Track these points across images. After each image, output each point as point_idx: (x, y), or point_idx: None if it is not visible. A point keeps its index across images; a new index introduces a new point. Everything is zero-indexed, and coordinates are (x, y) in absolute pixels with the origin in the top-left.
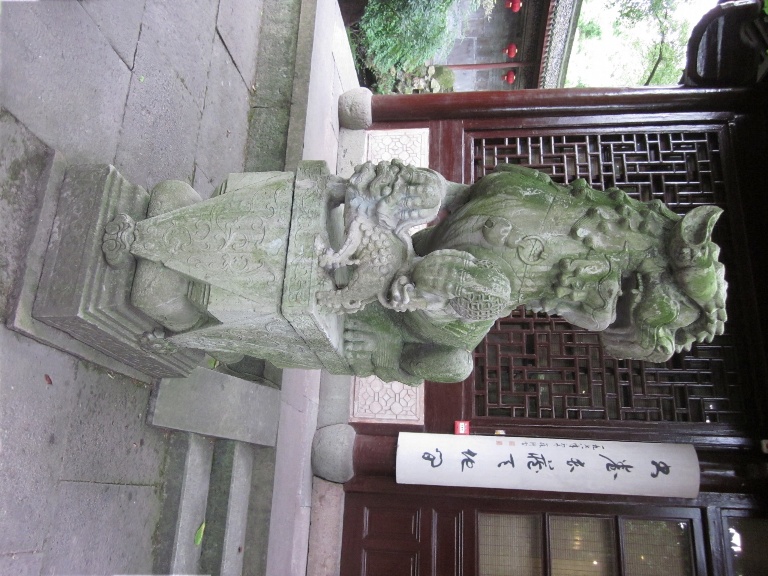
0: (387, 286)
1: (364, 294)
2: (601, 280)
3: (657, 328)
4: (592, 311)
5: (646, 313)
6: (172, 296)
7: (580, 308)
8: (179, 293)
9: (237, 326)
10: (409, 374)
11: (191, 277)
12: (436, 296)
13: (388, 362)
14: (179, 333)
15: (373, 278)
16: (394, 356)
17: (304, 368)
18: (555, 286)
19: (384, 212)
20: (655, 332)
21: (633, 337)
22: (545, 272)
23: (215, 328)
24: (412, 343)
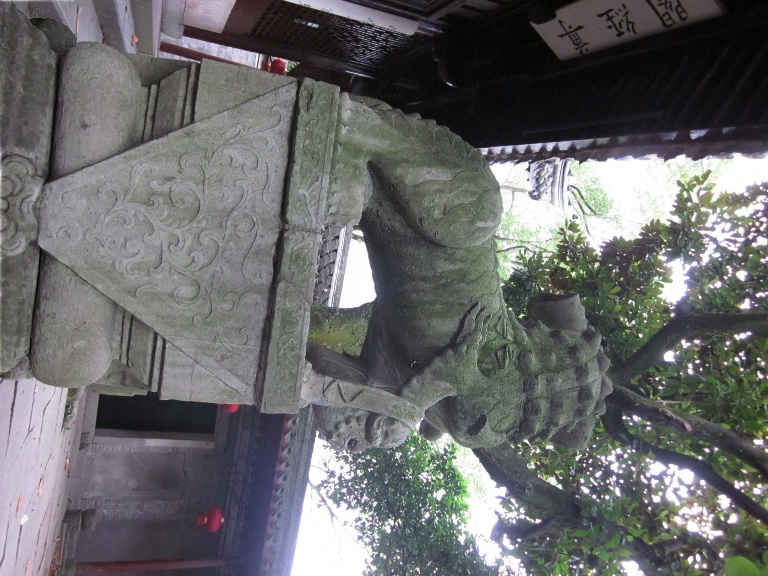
0: None
1: None
2: None
3: None
4: None
5: None
6: None
7: None
8: None
9: None
10: None
11: None
12: None
13: None
14: None
15: None
16: None
17: None
18: None
19: None
20: None
21: None
22: None
23: None
24: None
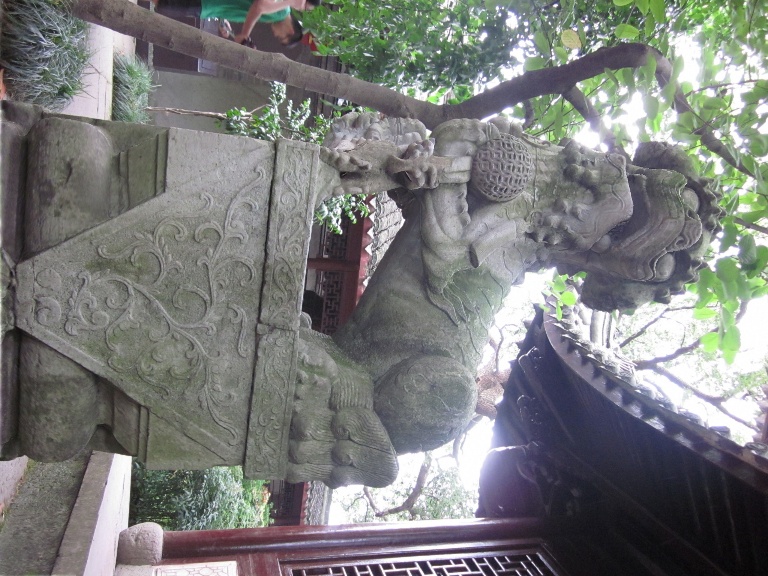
0: (400, 155)
1: (376, 153)
2: (607, 154)
3: (676, 191)
4: (611, 188)
5: (660, 176)
6: (104, 134)
7: (596, 200)
8: (110, 145)
9: (182, 206)
10: (386, 428)
11: (138, 129)
12: (463, 145)
13: (358, 395)
14: (56, 245)
15: (384, 143)
16: (365, 389)
17: (199, 461)
18: (568, 166)
19: (378, 128)
20: (677, 194)
21: (658, 220)
22: (554, 156)
23: (141, 213)
24: (388, 370)
